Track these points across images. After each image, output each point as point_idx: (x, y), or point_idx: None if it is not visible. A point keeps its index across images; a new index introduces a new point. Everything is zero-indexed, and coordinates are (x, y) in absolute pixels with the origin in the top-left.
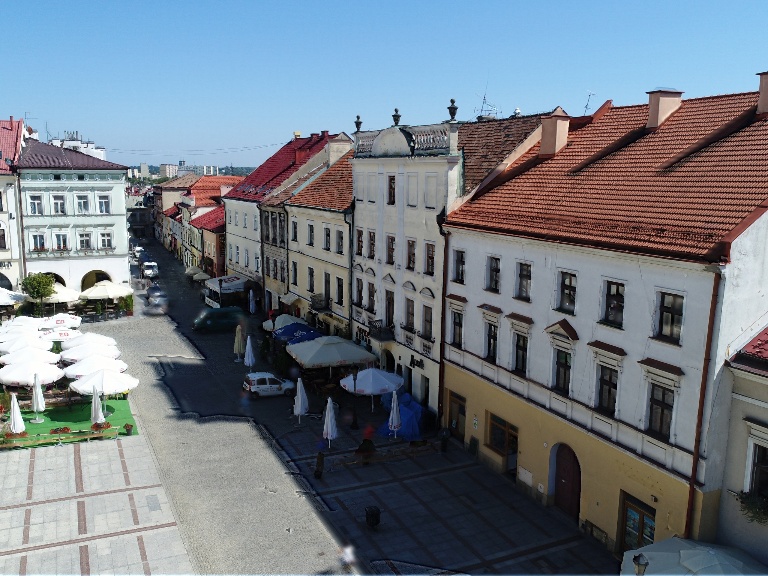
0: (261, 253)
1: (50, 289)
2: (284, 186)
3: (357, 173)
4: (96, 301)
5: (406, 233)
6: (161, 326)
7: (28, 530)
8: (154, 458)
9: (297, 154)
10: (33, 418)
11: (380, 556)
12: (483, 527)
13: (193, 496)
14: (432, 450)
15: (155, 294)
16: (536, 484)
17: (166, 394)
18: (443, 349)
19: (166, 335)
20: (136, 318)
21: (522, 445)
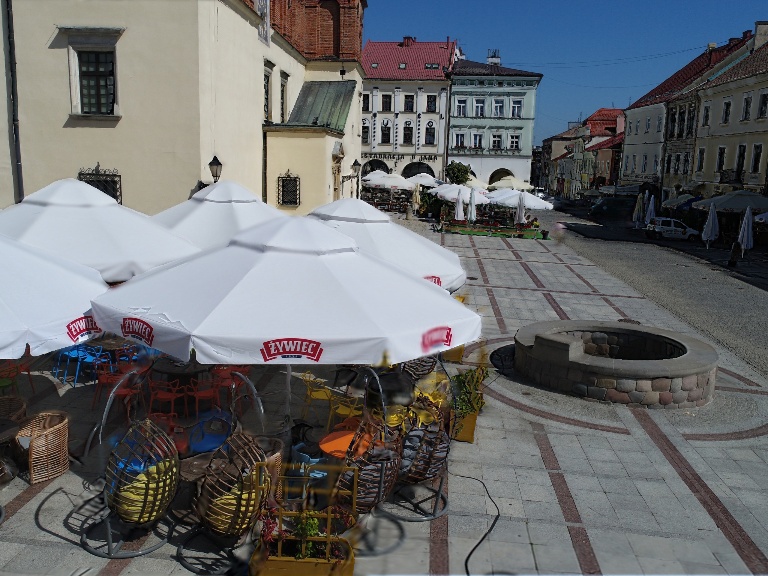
0: (663, 152)
1: (466, 177)
2: (696, 84)
3: None
4: None
5: None
6: (557, 214)
7: (478, 253)
8: (569, 247)
9: (713, 55)
10: None
11: None
12: None
13: (609, 260)
14: None
15: None
16: None
17: (571, 232)
18: None
19: (563, 217)
20: None
21: None
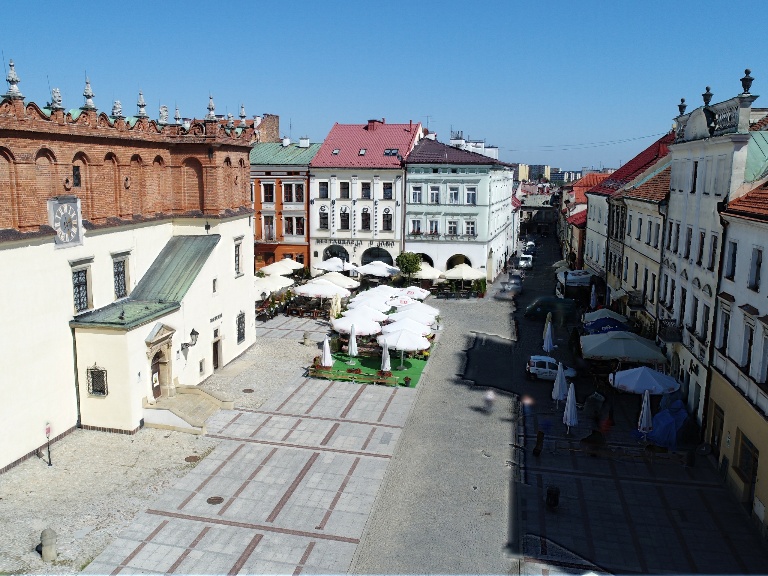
0: (606, 248)
1: (417, 266)
2: (638, 180)
3: (674, 161)
4: (452, 281)
5: (700, 224)
6: (501, 309)
7: (291, 432)
8: (413, 407)
9: (661, 147)
10: (349, 360)
11: (539, 532)
12: (673, 543)
13: (419, 441)
14: (678, 461)
15: (510, 281)
16: (766, 520)
17: (461, 362)
18: (712, 354)
19: (499, 317)
20: (485, 300)
21: (760, 472)
